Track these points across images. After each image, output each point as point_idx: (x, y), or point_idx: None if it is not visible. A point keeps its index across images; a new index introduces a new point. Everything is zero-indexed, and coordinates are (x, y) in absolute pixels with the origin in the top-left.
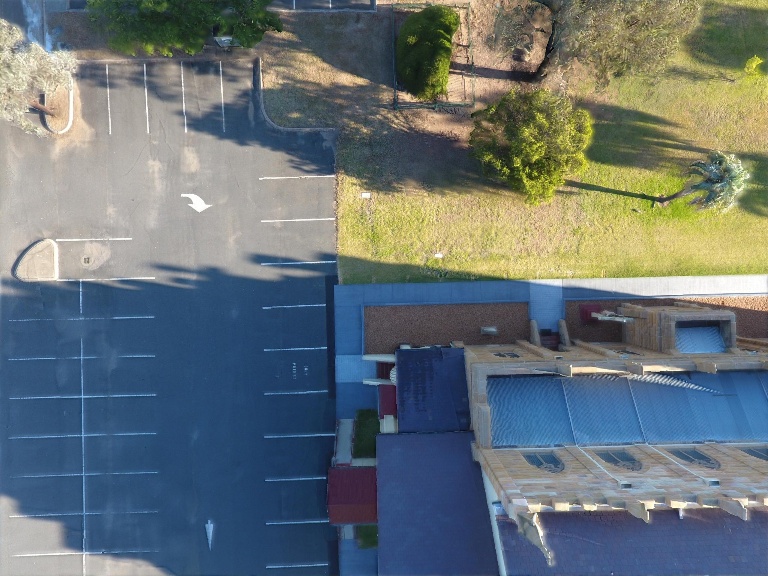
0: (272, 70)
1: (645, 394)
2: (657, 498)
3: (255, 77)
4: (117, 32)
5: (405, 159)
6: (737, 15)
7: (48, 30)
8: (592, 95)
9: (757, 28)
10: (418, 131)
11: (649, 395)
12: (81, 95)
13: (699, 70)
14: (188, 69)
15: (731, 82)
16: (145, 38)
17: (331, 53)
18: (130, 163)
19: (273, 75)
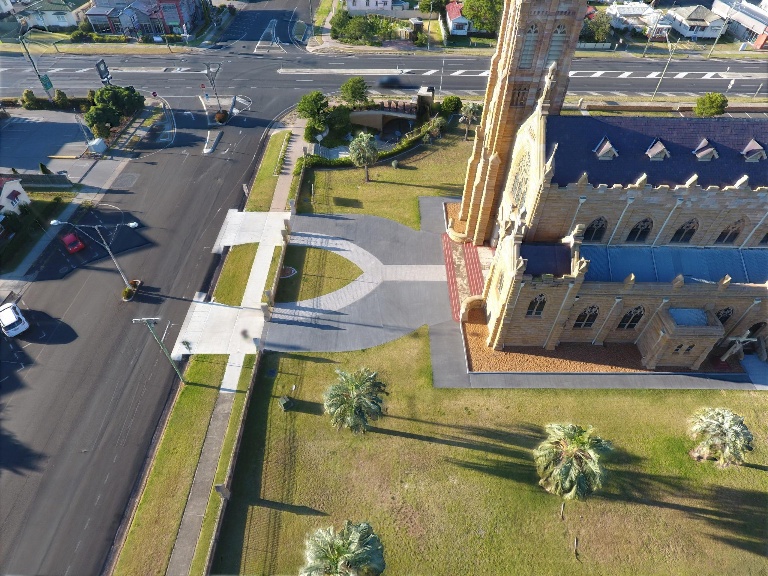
0: None
1: (738, 278)
2: None
3: None
4: None
5: None
6: None
7: None
8: None
9: None
10: None
11: (736, 277)
12: None
13: None
14: None
15: None
16: None
17: None
18: None
19: None
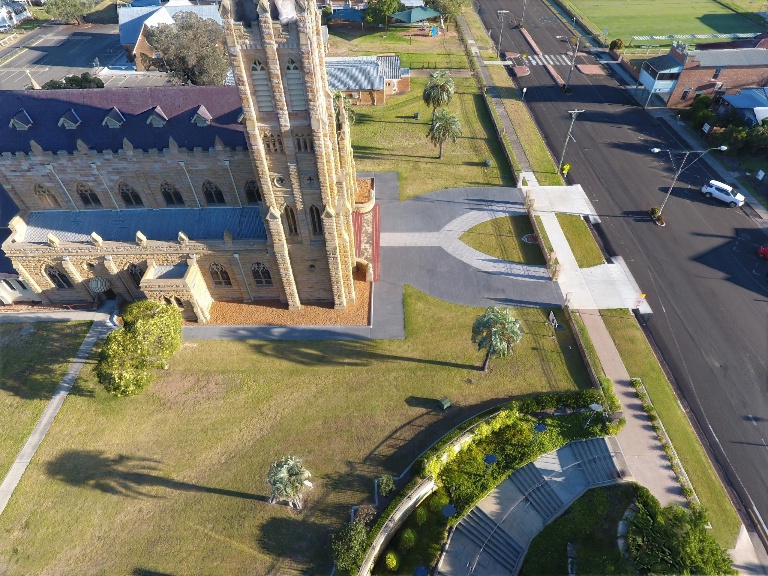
0: None
1: None
2: None
3: None
4: None
5: None
6: None
7: None
8: None
9: None
10: None
11: None
12: None
13: None
14: None
15: None
16: None
17: None
18: None
19: None
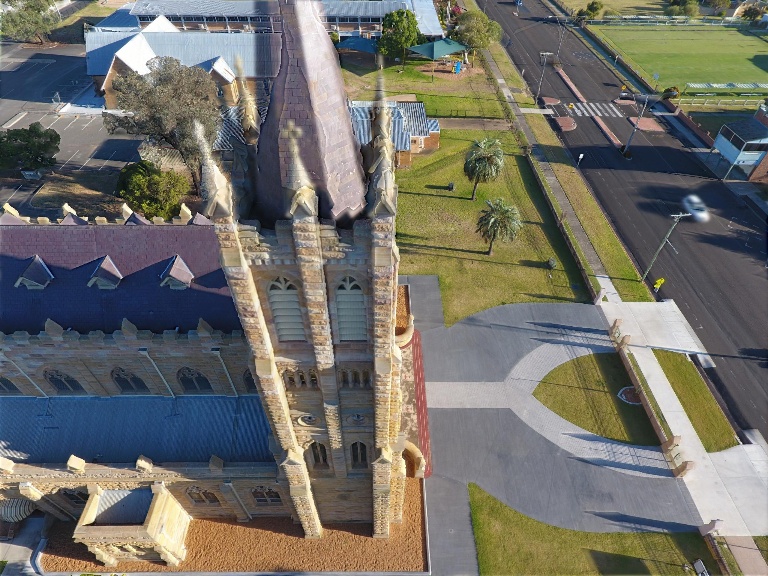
0: (48, 188)
1: None
2: None
3: (37, 190)
4: None
5: None
6: None
7: None
8: None
9: None
10: (119, 212)
11: None
12: None
13: None
14: (1, 187)
15: None
16: None
17: (87, 183)
18: None
19: (47, 189)
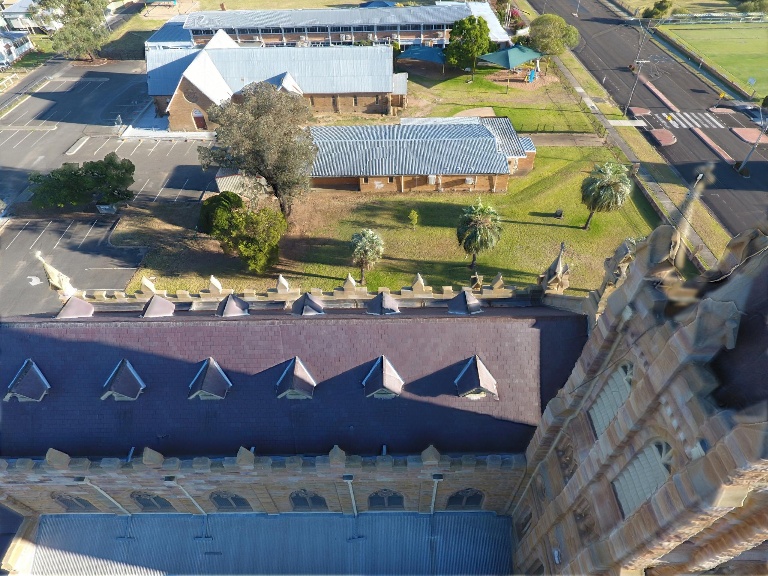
0: (125, 223)
1: None
2: (173, 295)
3: (113, 226)
4: (37, 194)
5: (189, 262)
6: (414, 204)
7: (8, 209)
8: (322, 235)
9: (427, 209)
10: (204, 250)
11: None
12: (3, 233)
13: (391, 225)
14: (76, 223)
15: (412, 230)
16: (51, 197)
17: (165, 217)
18: (7, 262)
19: (124, 225)
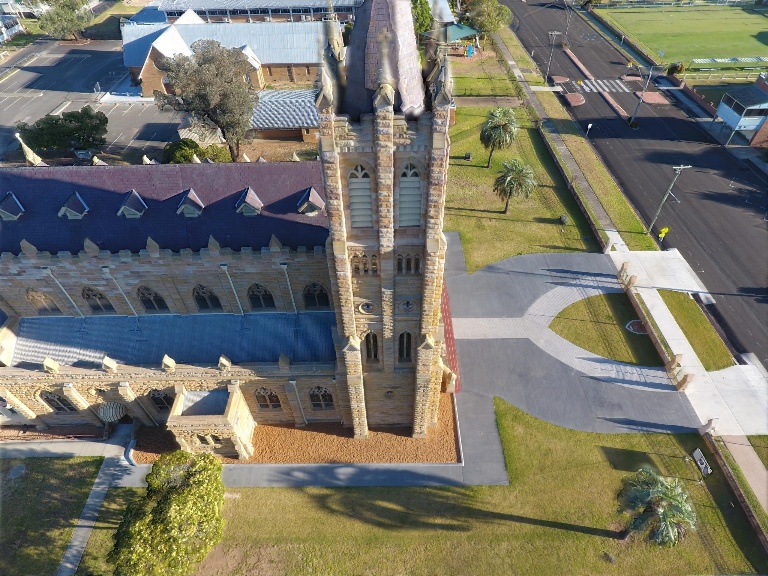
0: None
1: None
2: None
3: None
4: (24, 140)
5: None
6: None
7: None
8: None
9: None
10: None
11: None
12: None
13: None
14: None
15: None
16: (35, 142)
17: None
18: None
19: None
